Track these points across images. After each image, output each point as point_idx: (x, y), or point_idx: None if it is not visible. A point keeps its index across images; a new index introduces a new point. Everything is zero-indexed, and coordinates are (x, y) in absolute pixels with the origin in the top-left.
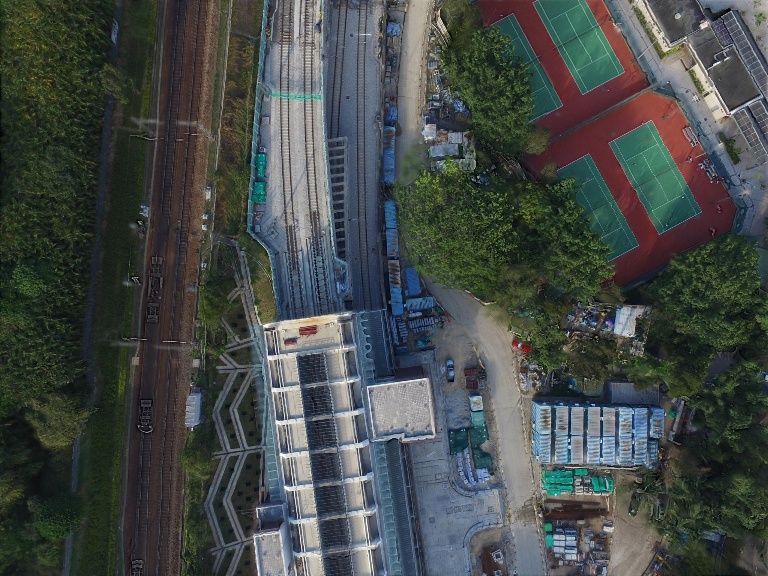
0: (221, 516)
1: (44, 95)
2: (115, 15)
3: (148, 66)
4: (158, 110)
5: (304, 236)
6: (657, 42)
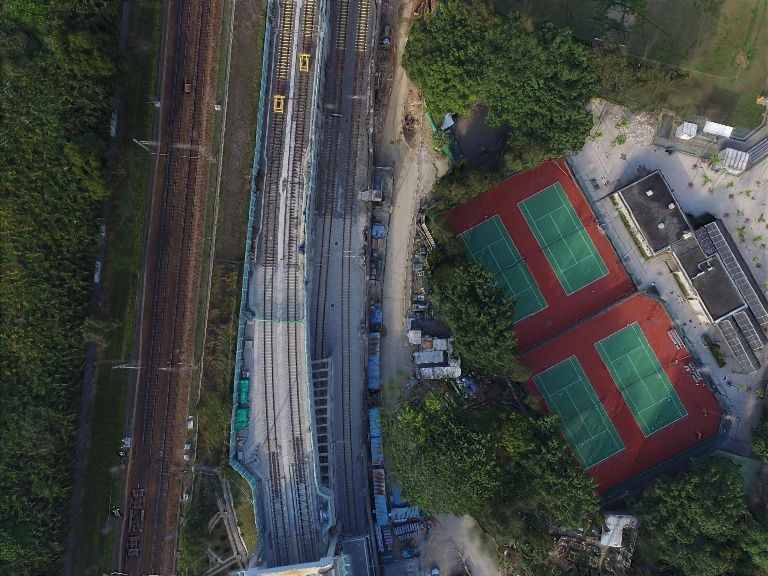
0: None
1: (24, 352)
2: (98, 257)
3: (131, 296)
4: (141, 338)
5: (287, 463)
6: (641, 247)
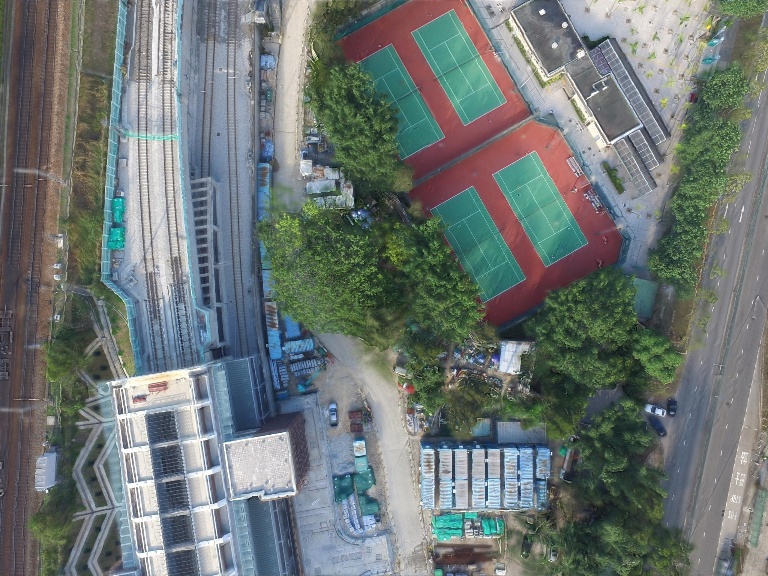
0: None
1: None
2: None
3: None
4: (5, 155)
5: (165, 283)
6: (537, 71)
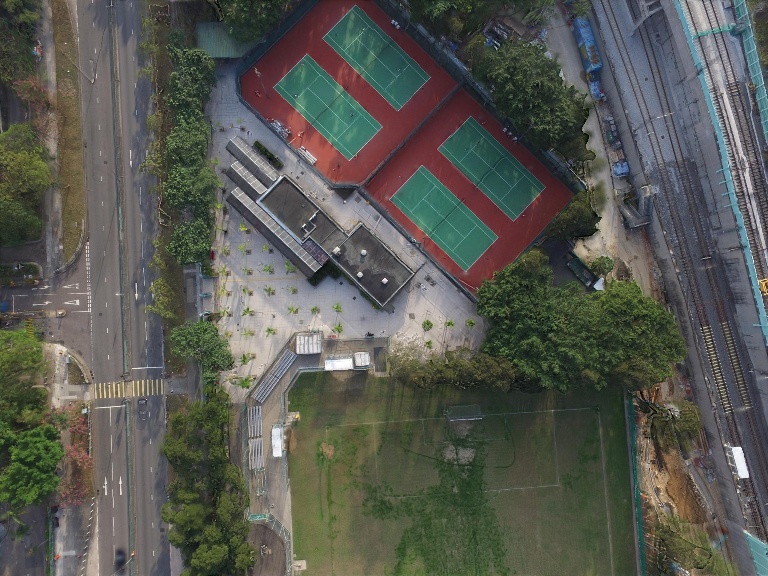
0: None
1: None
2: None
3: None
4: None
5: None
6: None
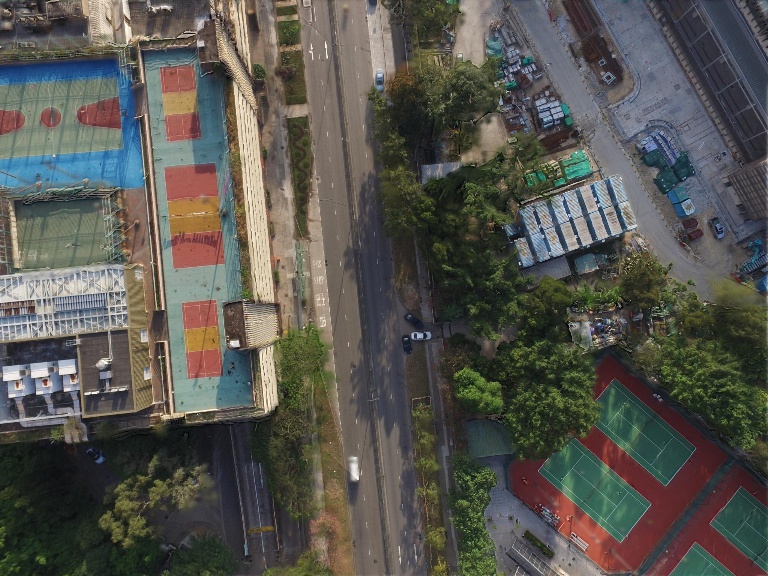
0: None
1: None
2: None
3: None
4: None
5: None
6: None
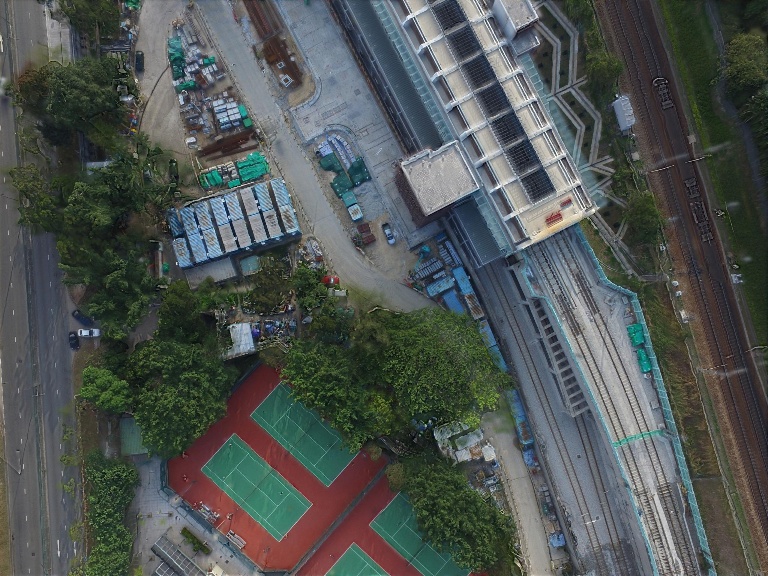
0: (557, 29)
1: None
2: None
3: None
4: (760, 378)
5: (579, 309)
6: None
